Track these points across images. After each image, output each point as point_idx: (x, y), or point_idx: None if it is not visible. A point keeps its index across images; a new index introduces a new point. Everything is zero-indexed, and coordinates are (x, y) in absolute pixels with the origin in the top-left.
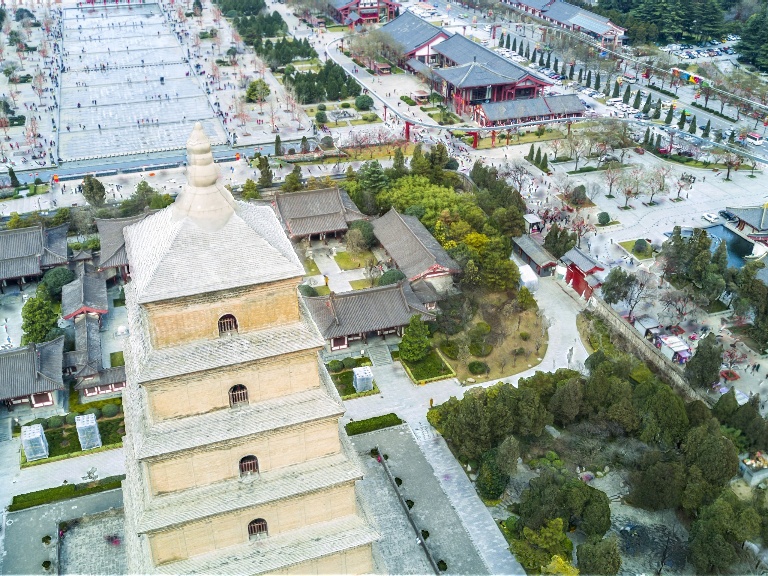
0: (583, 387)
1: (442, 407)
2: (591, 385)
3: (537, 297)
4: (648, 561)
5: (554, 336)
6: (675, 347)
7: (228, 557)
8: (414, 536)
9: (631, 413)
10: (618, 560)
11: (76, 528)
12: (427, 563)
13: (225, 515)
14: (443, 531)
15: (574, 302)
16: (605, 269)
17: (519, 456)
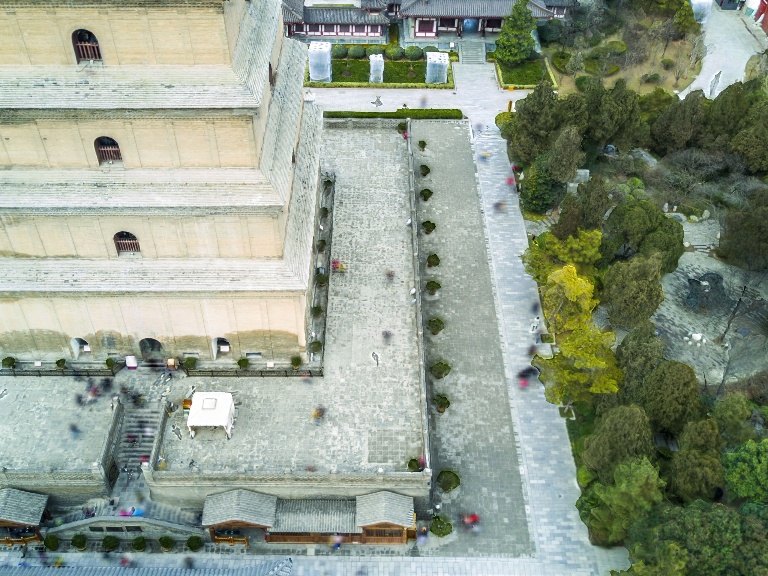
0: (708, 107)
1: (515, 105)
2: (719, 102)
3: (706, 29)
4: (714, 323)
5: (708, 72)
6: None
7: (46, 79)
8: (407, 216)
9: (763, 145)
10: (657, 292)
11: None
12: (408, 245)
13: (32, 7)
14: (456, 230)
15: (755, 42)
16: None
17: (583, 163)
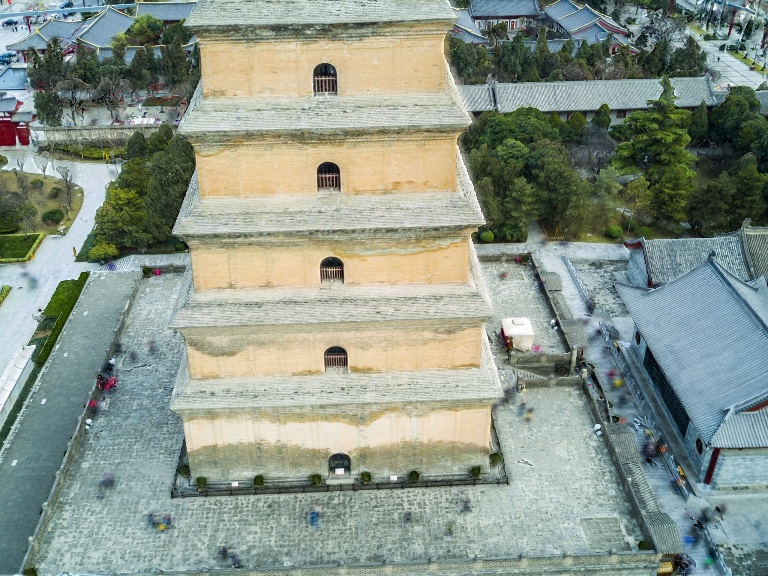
0: None
1: (108, 232)
2: None
3: None
4: None
5: (53, 173)
6: (148, 122)
7: None
8: None
9: None
10: None
11: (39, 566)
12: None
13: None
14: None
15: (17, 151)
16: (24, 102)
17: None
